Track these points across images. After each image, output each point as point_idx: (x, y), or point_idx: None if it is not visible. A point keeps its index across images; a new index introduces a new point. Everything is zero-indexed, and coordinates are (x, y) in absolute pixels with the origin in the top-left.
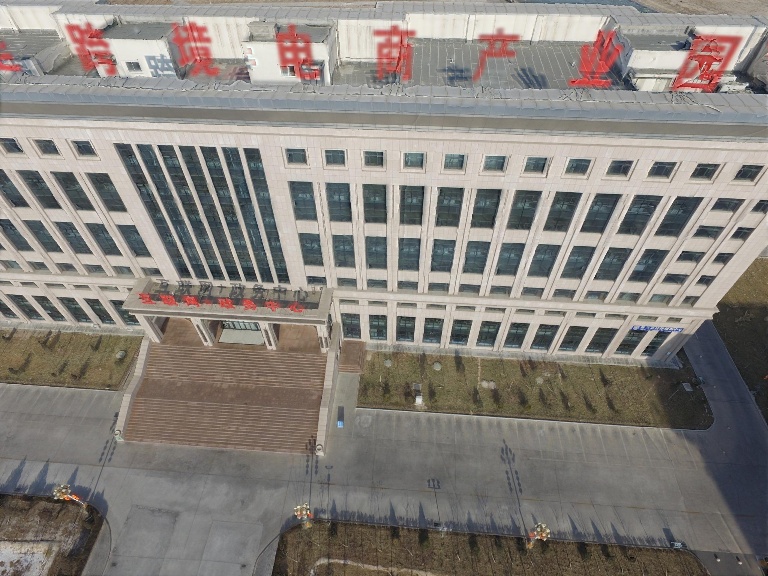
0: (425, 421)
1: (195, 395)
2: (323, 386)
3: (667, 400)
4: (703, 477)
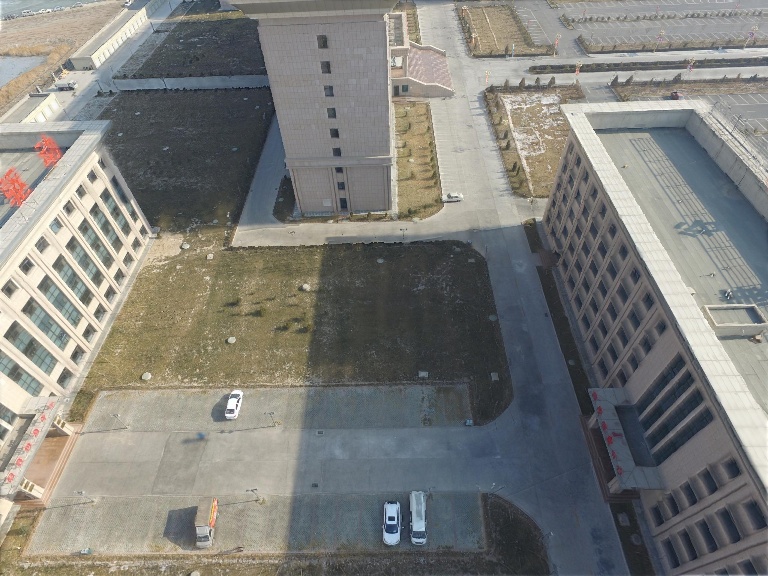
0: (425, 40)
1: (431, 74)
2: (420, 46)
3: (405, 7)
4: (432, 5)
